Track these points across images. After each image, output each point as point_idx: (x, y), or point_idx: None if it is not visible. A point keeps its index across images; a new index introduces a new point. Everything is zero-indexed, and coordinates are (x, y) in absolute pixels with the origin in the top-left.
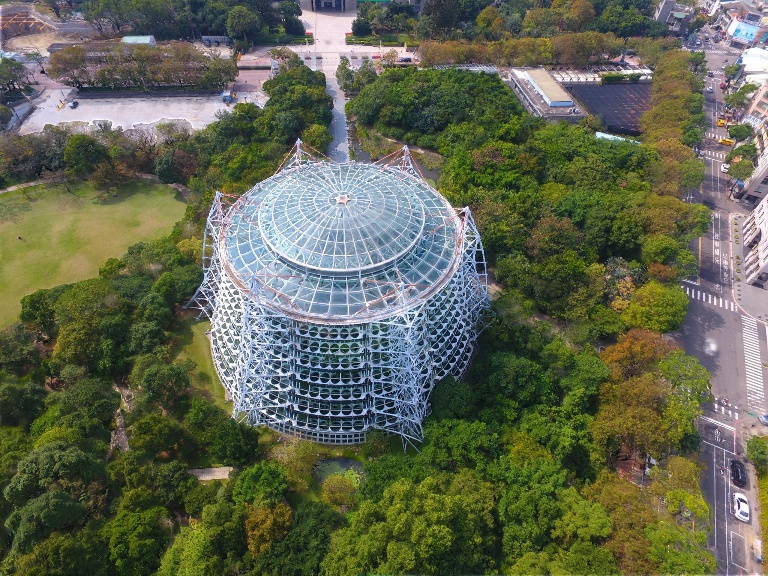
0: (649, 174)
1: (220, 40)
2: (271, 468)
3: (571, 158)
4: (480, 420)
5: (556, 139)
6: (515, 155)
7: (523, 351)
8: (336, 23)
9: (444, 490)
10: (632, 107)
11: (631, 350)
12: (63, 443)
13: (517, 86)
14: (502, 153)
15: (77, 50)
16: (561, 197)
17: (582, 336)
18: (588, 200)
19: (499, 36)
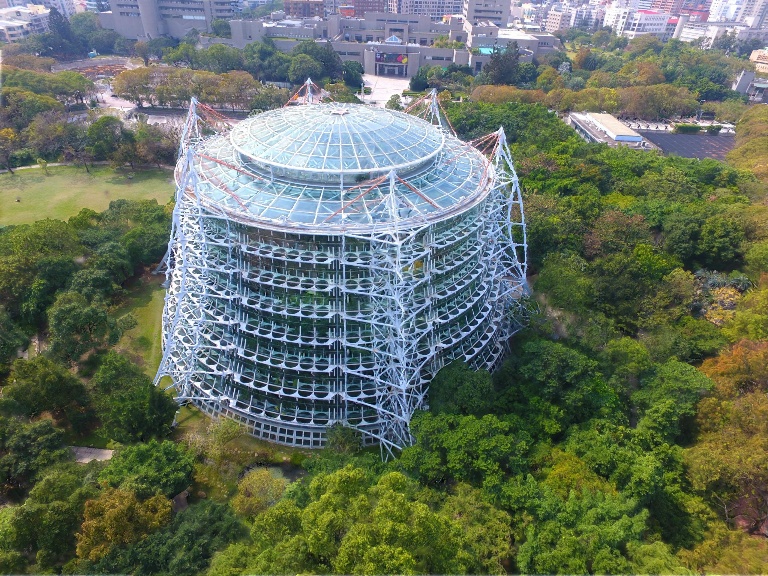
0: (745, 191)
1: (282, 86)
2: (171, 447)
3: (641, 174)
4: None
5: (623, 155)
6: (572, 165)
7: None
8: (396, 83)
9: None
10: (713, 152)
11: (746, 361)
12: None
13: (577, 127)
14: (556, 162)
15: (143, 70)
16: (629, 206)
17: (664, 344)
18: (665, 208)
19: None
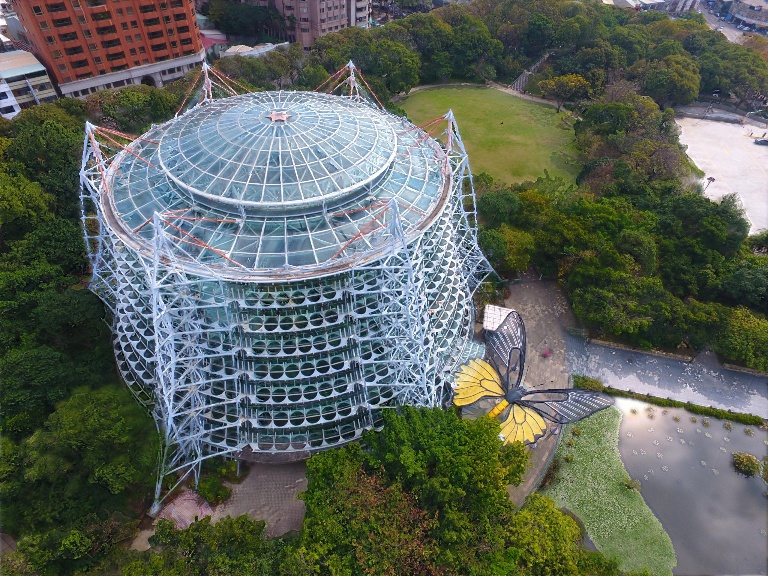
0: None
1: None
2: None
3: None
4: None
5: None
6: None
7: None
8: None
9: (0, 265)
10: None
11: None
12: None
13: None
14: None
15: None
16: None
17: None
18: None
19: None
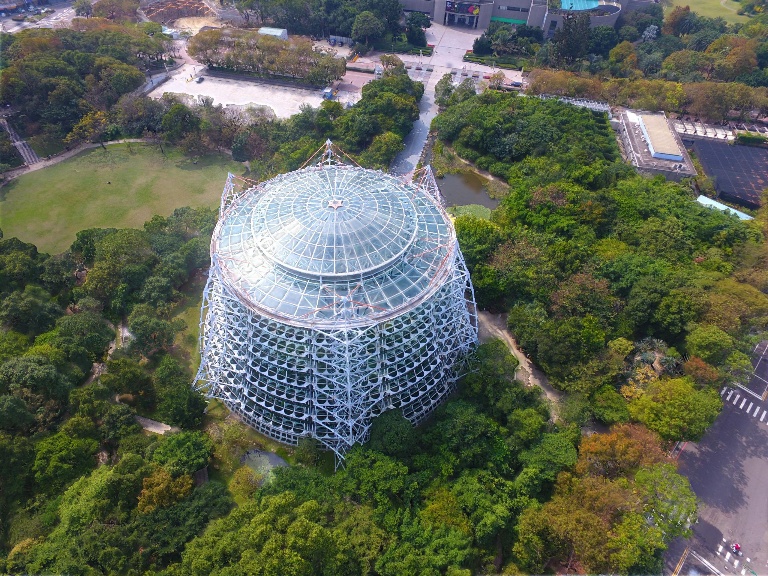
0: (738, 255)
1: (345, 41)
2: (197, 440)
3: (648, 217)
4: (412, 464)
5: (637, 193)
6: (581, 201)
7: (492, 408)
8: (462, 39)
9: (337, 520)
10: (762, 176)
11: (614, 446)
12: (43, 359)
13: None
14: (566, 196)
15: (214, 33)
16: (616, 257)
17: (569, 413)
18: (646, 267)
19: (628, 74)
